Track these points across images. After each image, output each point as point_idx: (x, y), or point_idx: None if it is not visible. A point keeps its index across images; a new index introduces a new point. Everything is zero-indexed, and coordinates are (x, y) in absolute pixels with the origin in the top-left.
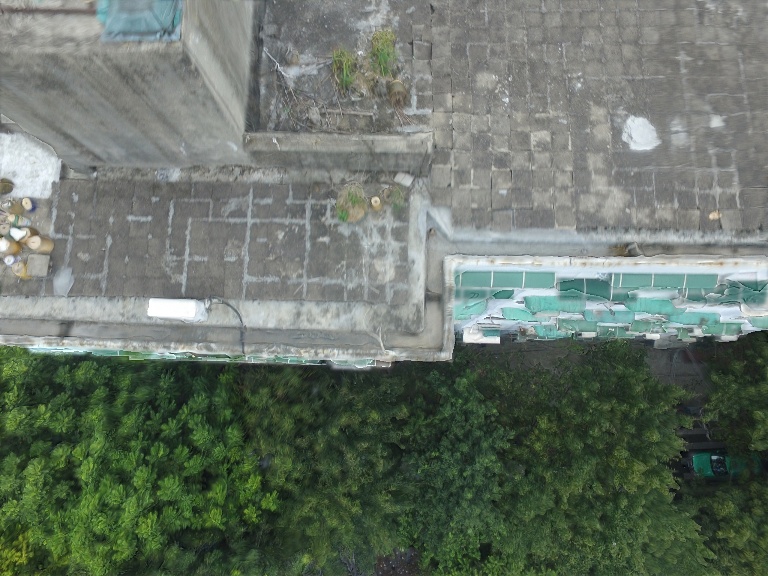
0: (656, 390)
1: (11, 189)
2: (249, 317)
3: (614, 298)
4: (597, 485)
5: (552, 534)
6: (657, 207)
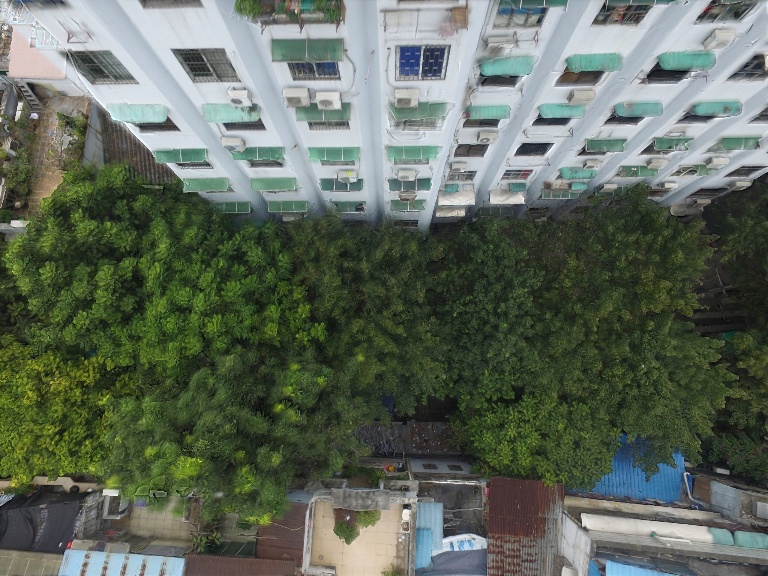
0: (677, 229)
1: None
2: None
3: None
4: (625, 311)
5: (583, 368)
6: None
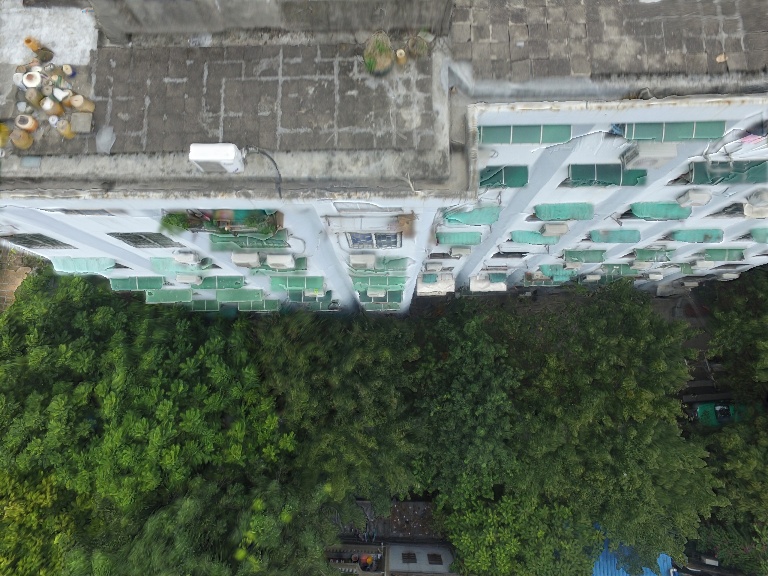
0: (661, 327)
1: (51, 57)
2: (283, 168)
3: (624, 182)
4: (607, 418)
5: (564, 470)
6: (667, 53)
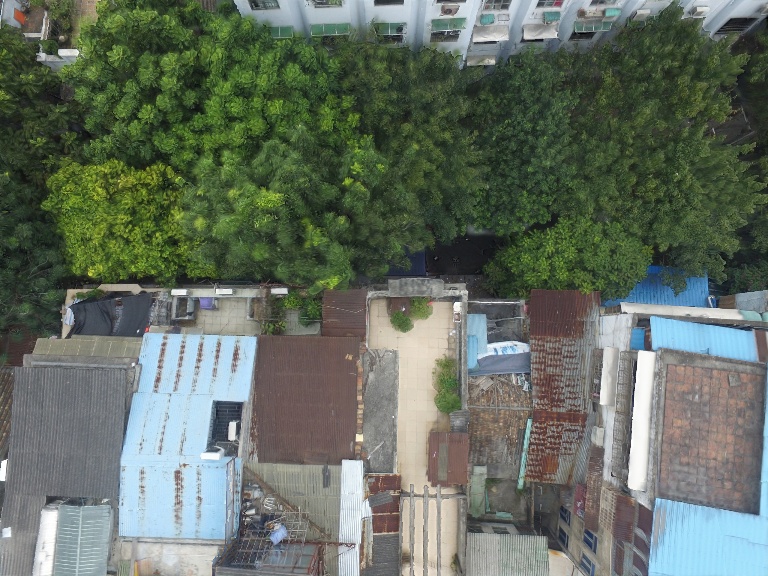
0: (710, 46)
1: None
2: None
3: None
4: (660, 121)
5: (617, 185)
6: None
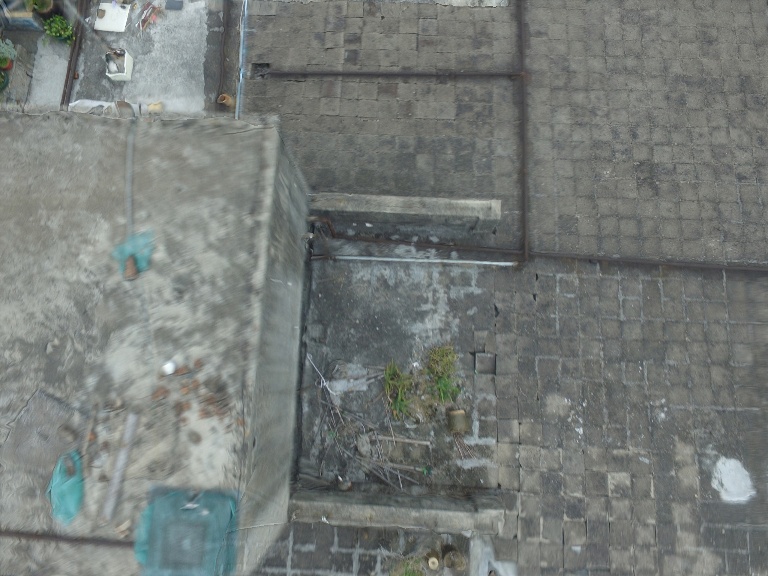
0: None
1: None
2: None
3: None
4: None
5: None
6: (752, 575)
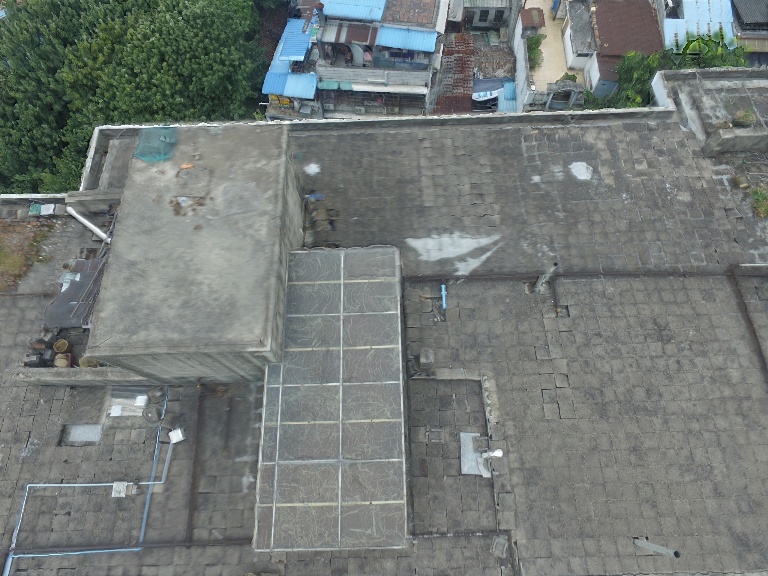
0: None
1: None
2: None
3: None
4: None
5: None
6: None
